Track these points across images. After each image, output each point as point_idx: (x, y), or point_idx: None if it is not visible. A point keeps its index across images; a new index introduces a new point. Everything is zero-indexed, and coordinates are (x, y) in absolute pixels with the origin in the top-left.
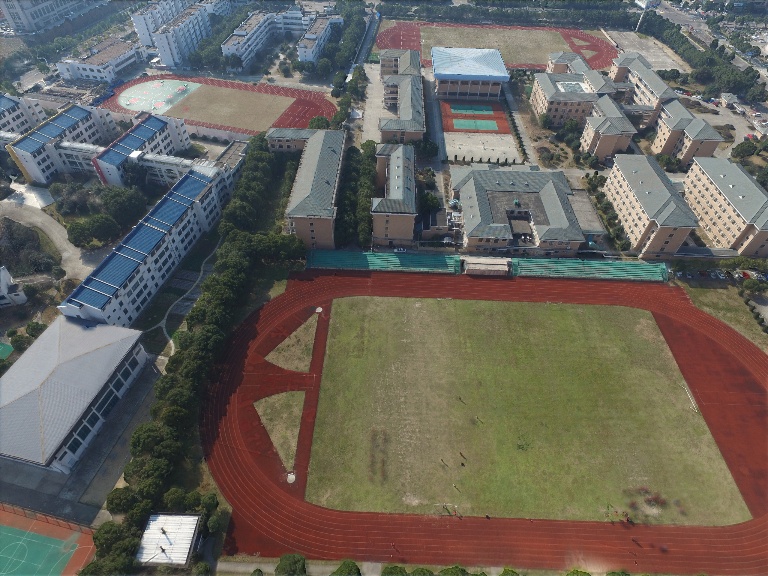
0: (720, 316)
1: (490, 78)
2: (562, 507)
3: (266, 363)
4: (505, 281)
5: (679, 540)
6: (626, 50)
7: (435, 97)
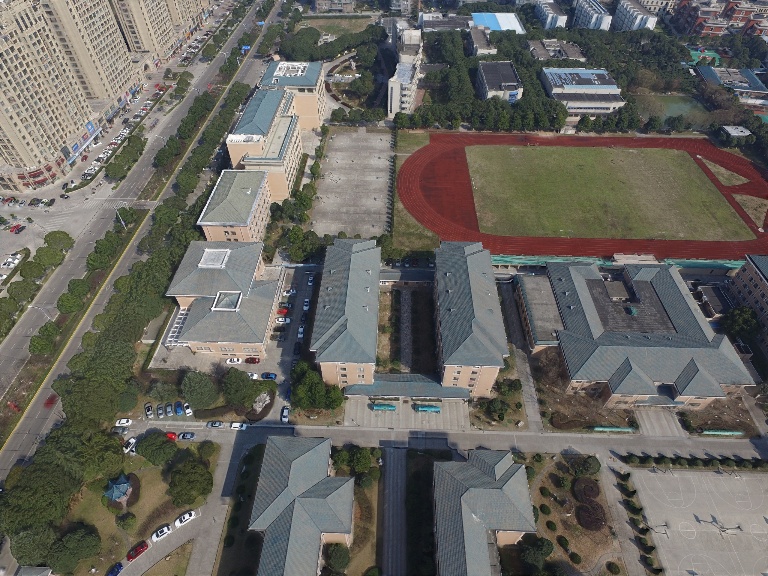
0: (422, 229)
1: None
2: (558, 149)
3: (765, 198)
4: (611, 255)
5: (504, 142)
6: None
7: None
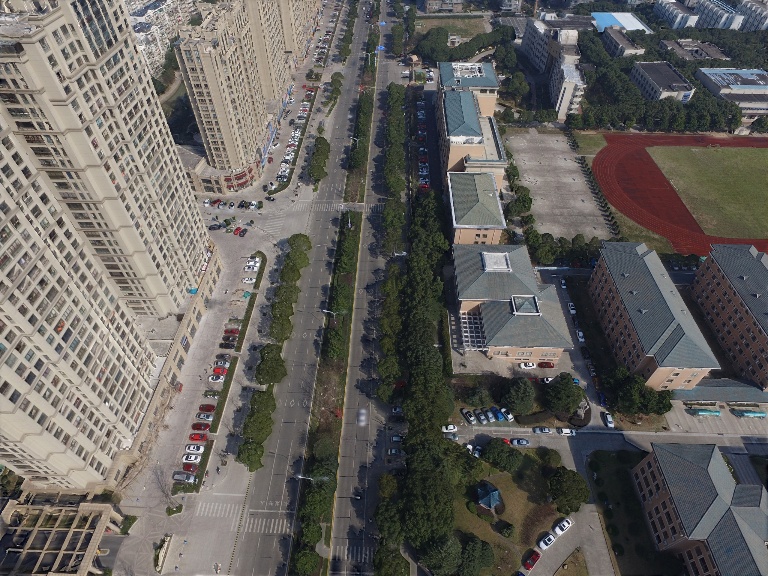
0: (646, 231)
1: None
2: (740, 150)
3: None
4: None
5: None
6: None
7: None
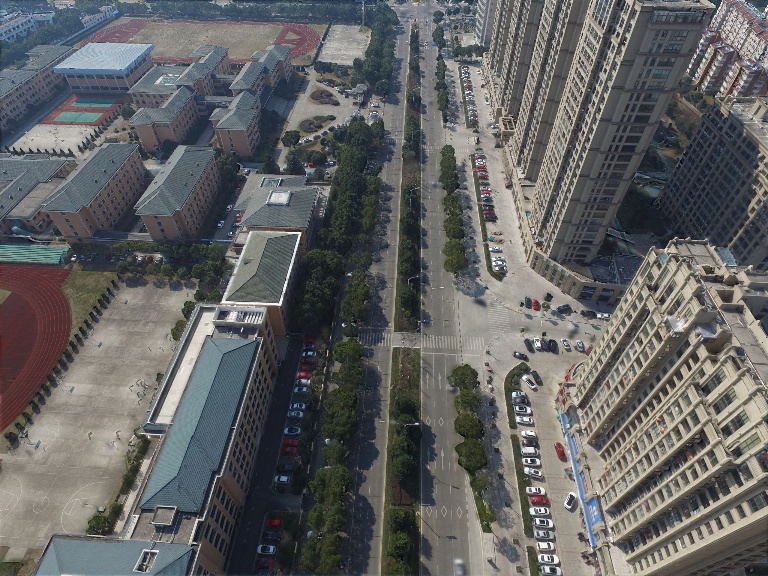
0: (73, 297)
1: (107, 72)
2: None
3: None
4: None
5: None
6: (328, 43)
7: (72, 91)
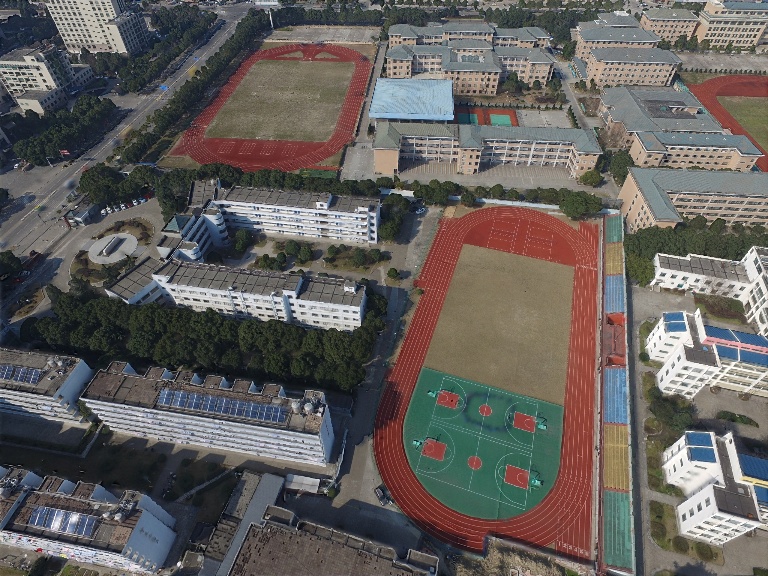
0: (703, 80)
1: None
2: None
3: None
4: None
5: None
6: None
7: None
